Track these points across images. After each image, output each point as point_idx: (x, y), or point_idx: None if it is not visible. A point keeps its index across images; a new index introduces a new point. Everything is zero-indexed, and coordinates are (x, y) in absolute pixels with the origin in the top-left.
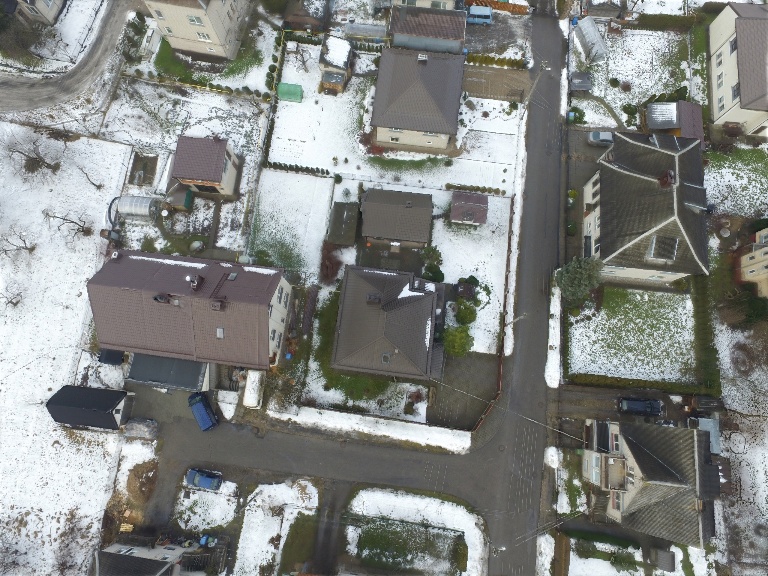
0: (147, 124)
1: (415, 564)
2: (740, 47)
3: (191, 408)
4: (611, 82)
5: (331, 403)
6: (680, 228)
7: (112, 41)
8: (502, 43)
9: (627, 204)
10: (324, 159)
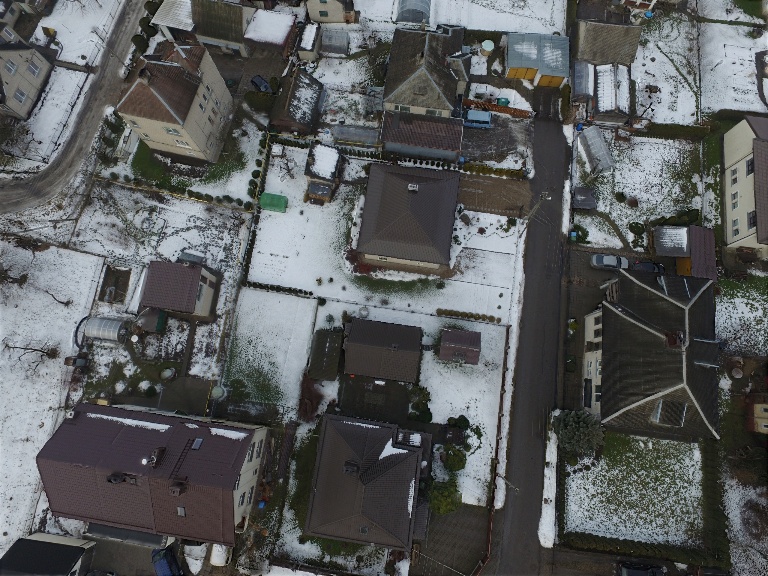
0: (121, 233)
1: None
2: (757, 173)
3: (154, 566)
4: (617, 197)
5: (306, 558)
6: (689, 395)
7: (88, 139)
8: (501, 149)
9: (631, 358)
10: (307, 277)
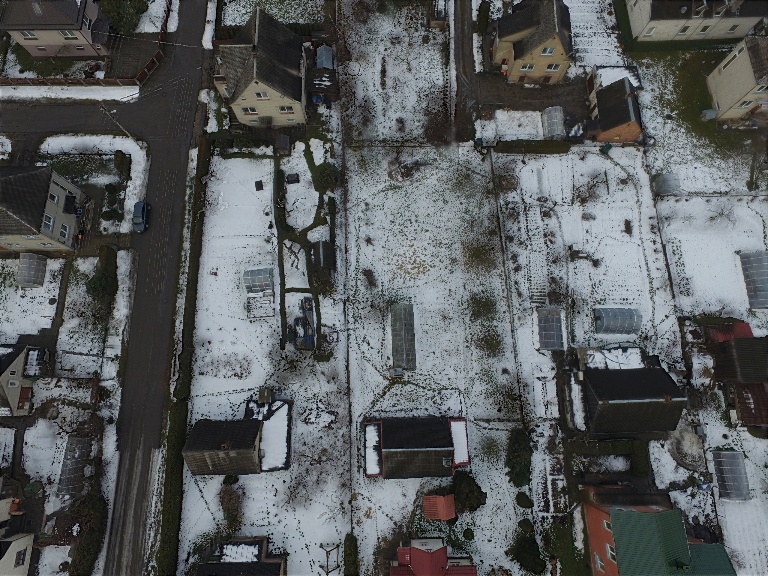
0: None
1: (90, 181)
2: None
3: None
4: None
5: None
6: None
7: None
8: None
9: None
10: None
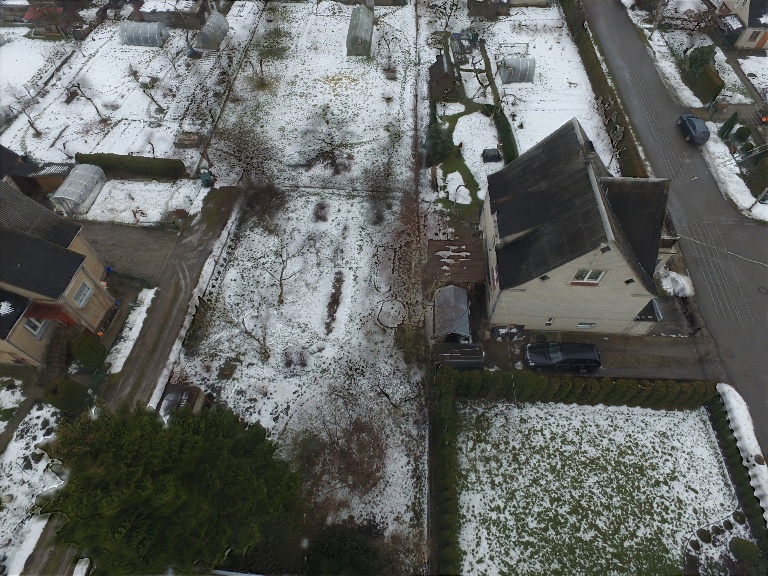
0: None
1: None
2: None
3: None
4: None
5: None
6: None
7: None
8: None
9: None
10: None
